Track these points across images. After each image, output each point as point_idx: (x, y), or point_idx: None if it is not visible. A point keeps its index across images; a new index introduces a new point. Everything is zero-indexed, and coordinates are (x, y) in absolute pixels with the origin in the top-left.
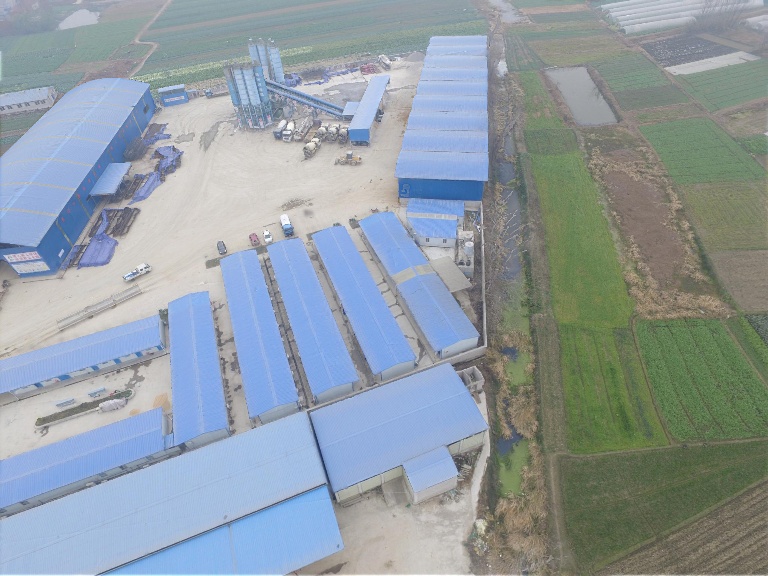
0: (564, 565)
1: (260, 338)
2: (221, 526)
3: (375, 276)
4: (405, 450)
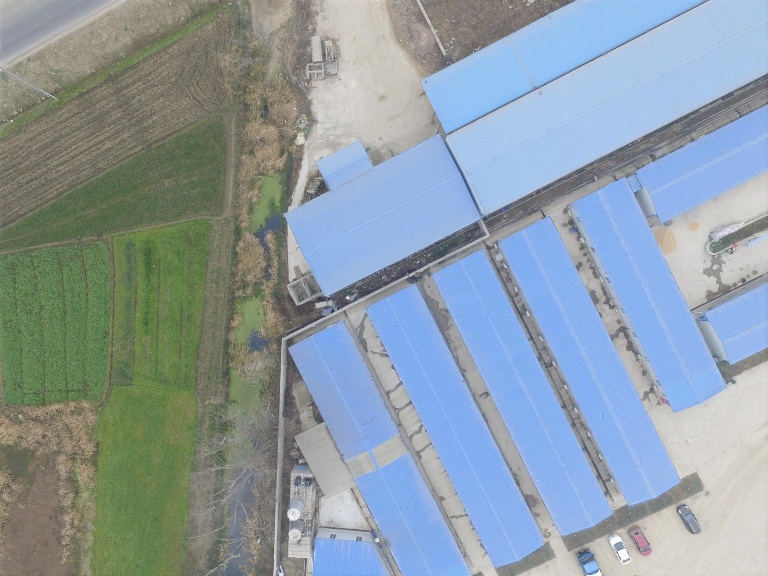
0: (232, 115)
1: (570, 327)
2: (542, 85)
3: (433, 464)
4: (371, 182)
